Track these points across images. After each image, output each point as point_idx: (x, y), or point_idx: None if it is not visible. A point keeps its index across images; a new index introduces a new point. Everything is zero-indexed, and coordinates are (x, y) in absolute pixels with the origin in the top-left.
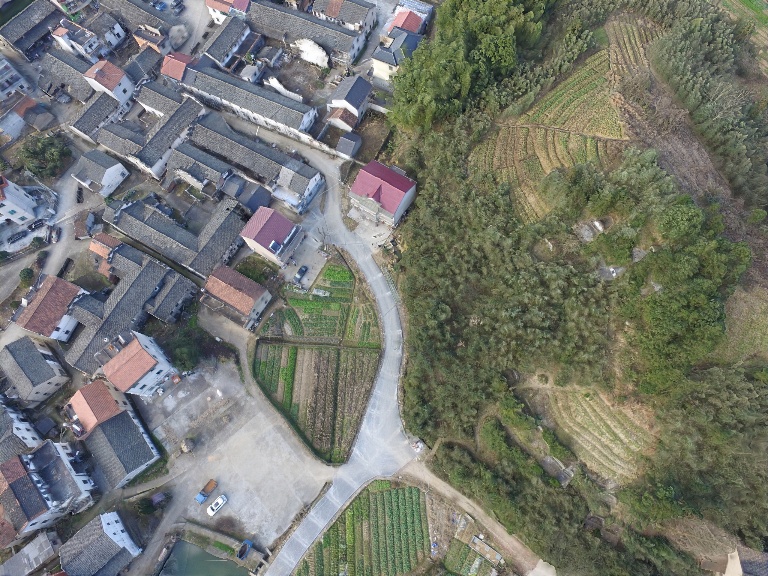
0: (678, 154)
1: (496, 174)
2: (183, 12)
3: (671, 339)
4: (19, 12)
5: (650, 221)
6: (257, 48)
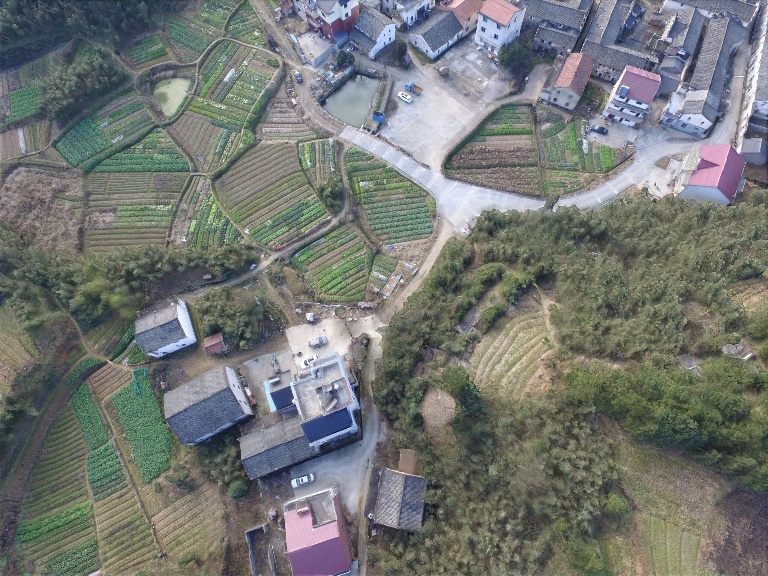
0: None
1: None
2: None
3: (635, 382)
4: None
5: None
6: None
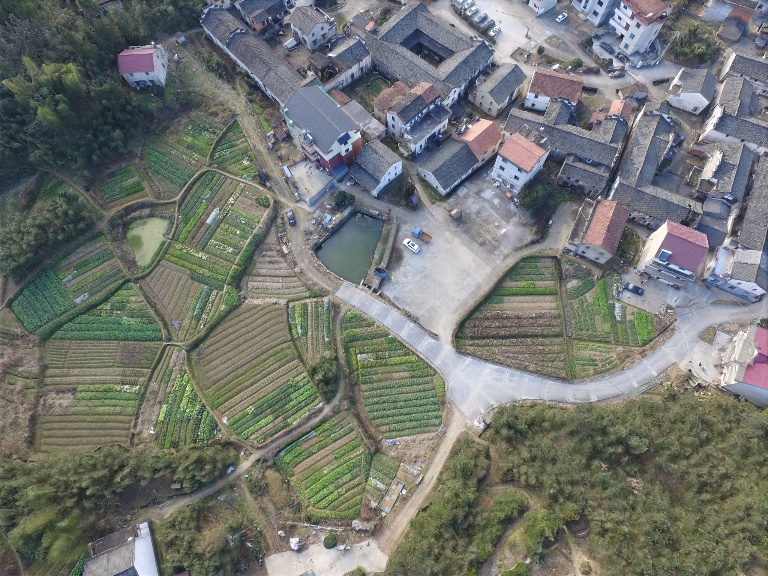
0: None
1: None
2: None
3: None
4: None
5: None
6: None
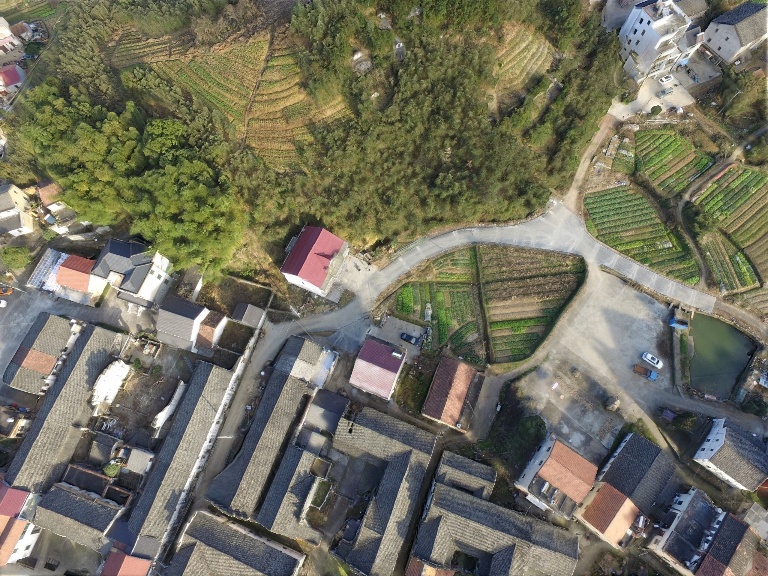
0: (283, 3)
1: (300, 145)
2: None
3: None
4: None
5: None
6: None
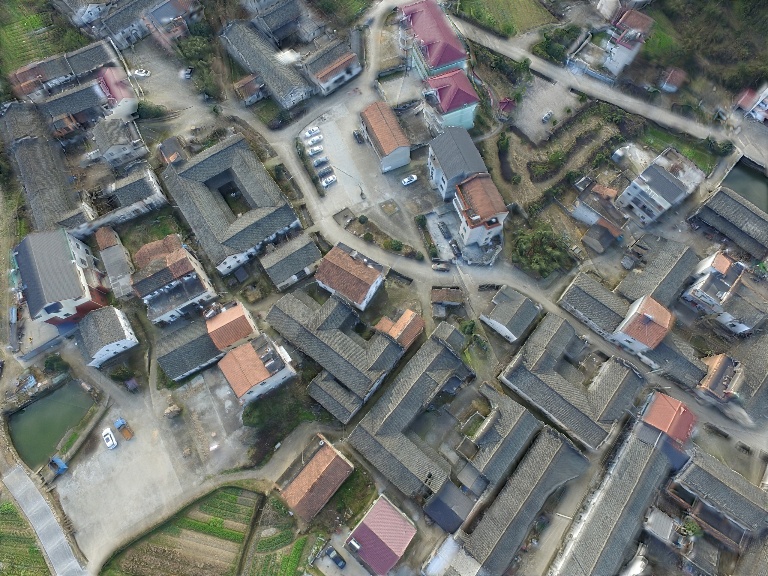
0: None
1: None
2: None
3: None
4: (759, 208)
5: None
6: None
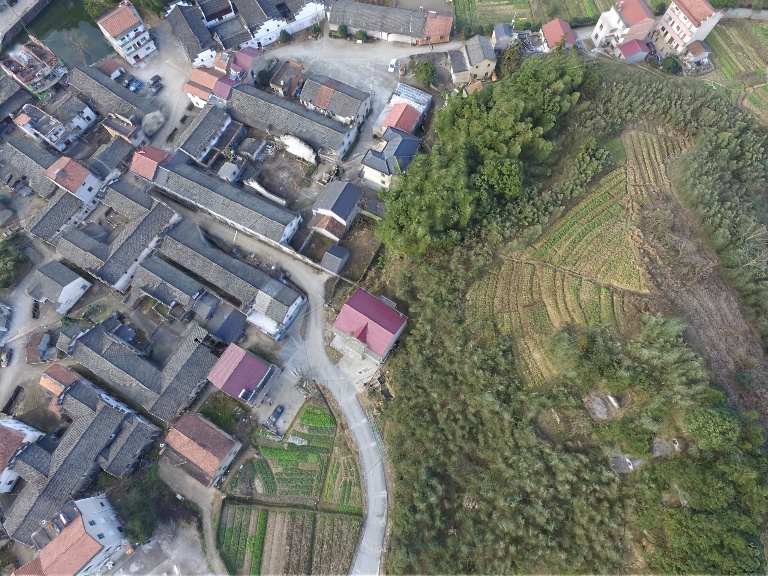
0: (705, 313)
1: (497, 319)
2: (161, 91)
3: None
4: None
5: (674, 408)
6: (239, 138)
